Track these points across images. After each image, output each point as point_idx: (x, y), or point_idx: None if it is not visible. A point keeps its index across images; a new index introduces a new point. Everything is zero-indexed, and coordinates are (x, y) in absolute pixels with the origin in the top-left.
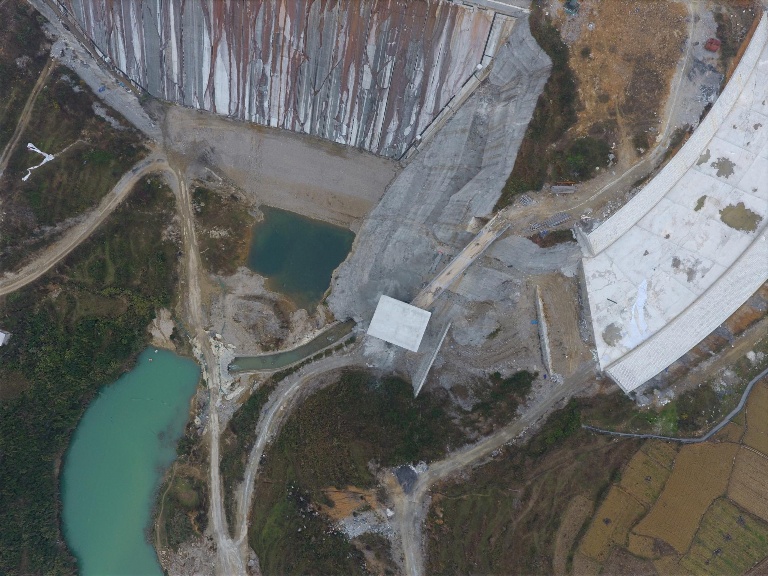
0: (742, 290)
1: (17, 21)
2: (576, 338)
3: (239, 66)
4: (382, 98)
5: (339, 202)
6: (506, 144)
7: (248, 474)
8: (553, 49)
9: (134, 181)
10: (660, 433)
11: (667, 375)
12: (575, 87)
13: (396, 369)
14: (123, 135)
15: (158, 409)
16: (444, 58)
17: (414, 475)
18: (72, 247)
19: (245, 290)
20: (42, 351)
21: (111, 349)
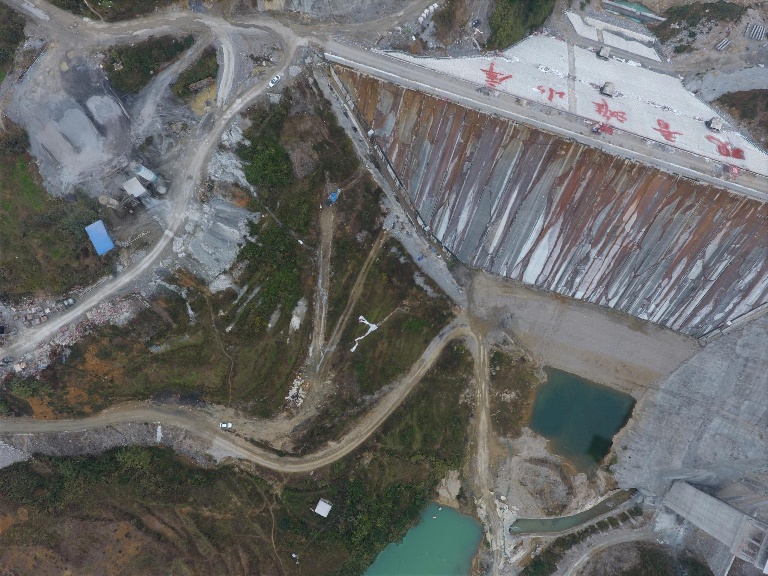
0: None
1: (364, 199)
2: None
3: (564, 247)
4: (704, 288)
5: (627, 371)
6: None
7: None
8: None
9: (441, 347)
10: None
11: None
12: None
13: (686, 547)
14: (436, 303)
15: (436, 564)
16: None
17: None
18: (386, 415)
19: (530, 453)
20: (357, 520)
21: (408, 512)
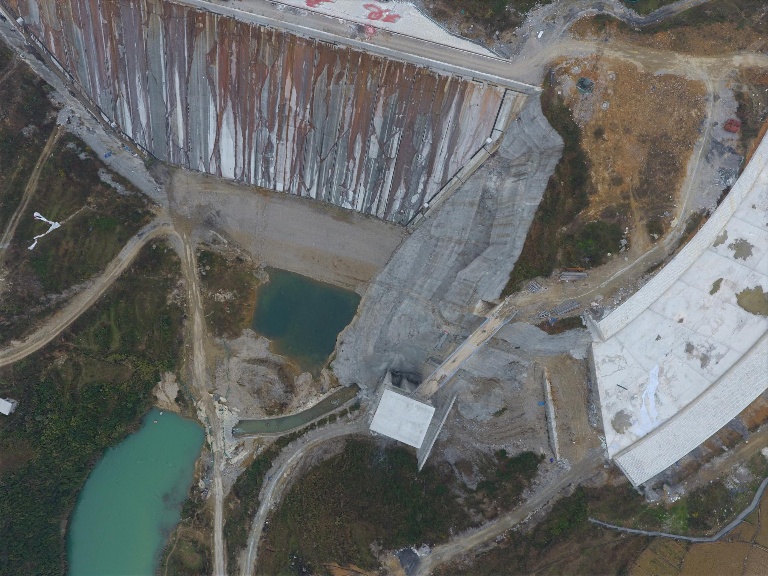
0: (758, 381)
1: (23, 91)
2: (584, 423)
3: (245, 134)
4: (389, 167)
5: (345, 265)
6: (515, 224)
7: (251, 541)
8: (565, 130)
9: (139, 246)
10: (669, 531)
11: (678, 469)
12: (587, 169)
13: None
14: (129, 200)
15: (163, 470)
16: (453, 131)
17: (417, 558)
18: (78, 314)
19: (250, 353)
20: (48, 419)
21: (116, 414)
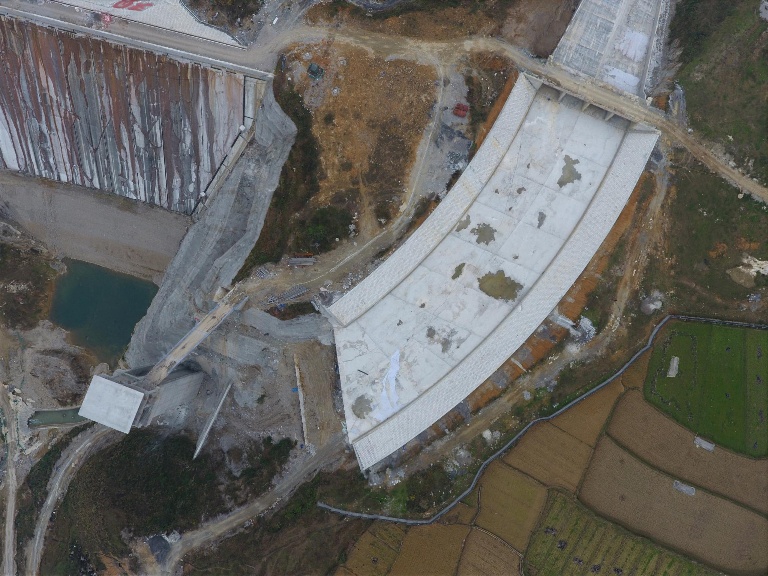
0: (489, 364)
1: None
2: (329, 409)
3: (16, 124)
4: (159, 156)
5: (138, 256)
6: (258, 211)
7: (38, 531)
8: (295, 116)
9: None
10: (389, 514)
11: (403, 453)
12: (317, 155)
13: (186, 427)
14: None
15: None
16: (207, 119)
17: (167, 545)
18: None
19: (45, 344)
20: None
21: None
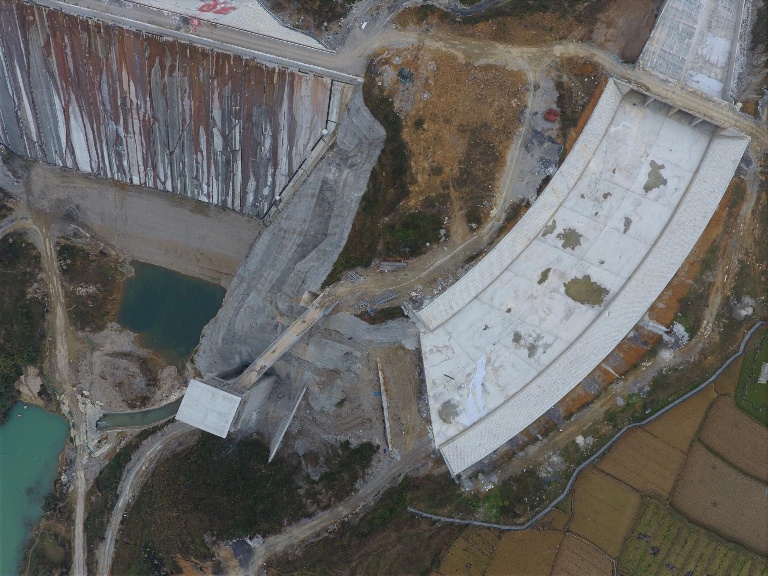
0: (578, 369)
1: None
2: (414, 413)
3: (93, 127)
4: (236, 159)
5: (207, 259)
6: (344, 215)
7: (109, 533)
8: (386, 120)
9: None
10: (482, 519)
11: (494, 458)
12: (408, 159)
13: (258, 430)
14: None
15: (29, 464)
16: (289, 123)
17: (250, 549)
18: None
19: (113, 347)
20: None
21: None
